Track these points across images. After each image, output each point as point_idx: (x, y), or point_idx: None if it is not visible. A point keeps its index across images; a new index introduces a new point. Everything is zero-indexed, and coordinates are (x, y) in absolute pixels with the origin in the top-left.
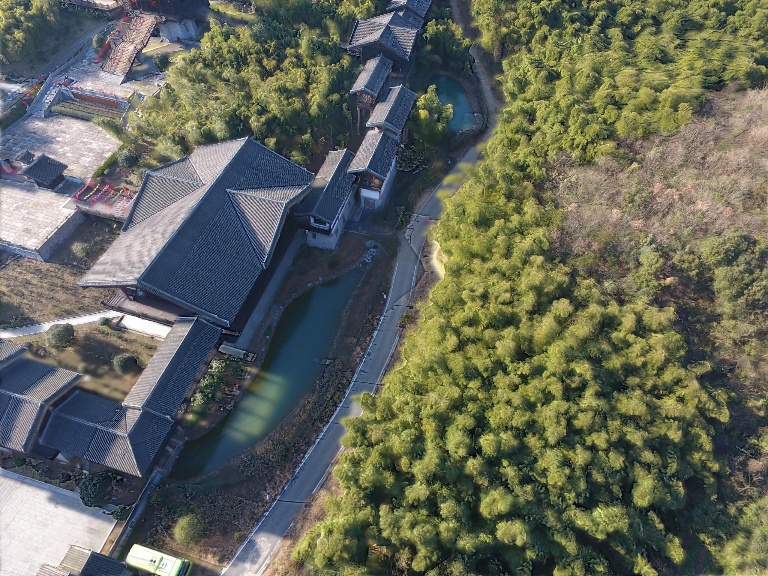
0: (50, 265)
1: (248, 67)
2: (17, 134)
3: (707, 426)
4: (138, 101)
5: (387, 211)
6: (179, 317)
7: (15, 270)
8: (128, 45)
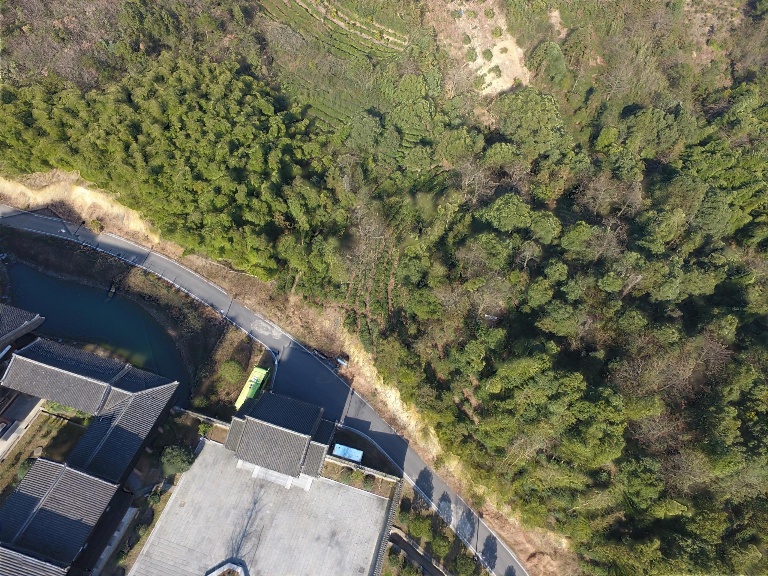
0: None
1: None
2: None
3: (240, 75)
4: None
5: None
6: (2, 380)
7: None
8: None
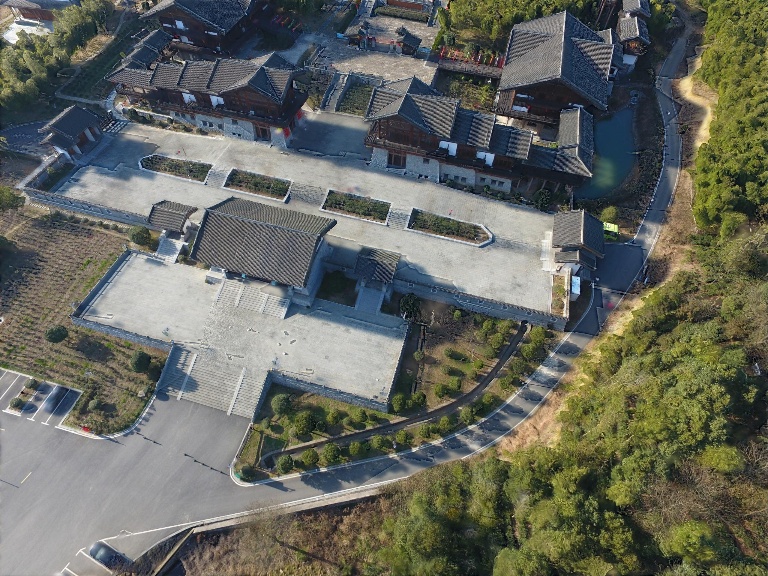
0: None
1: None
2: None
3: None
4: (437, 5)
5: None
6: (564, 110)
7: None
8: None
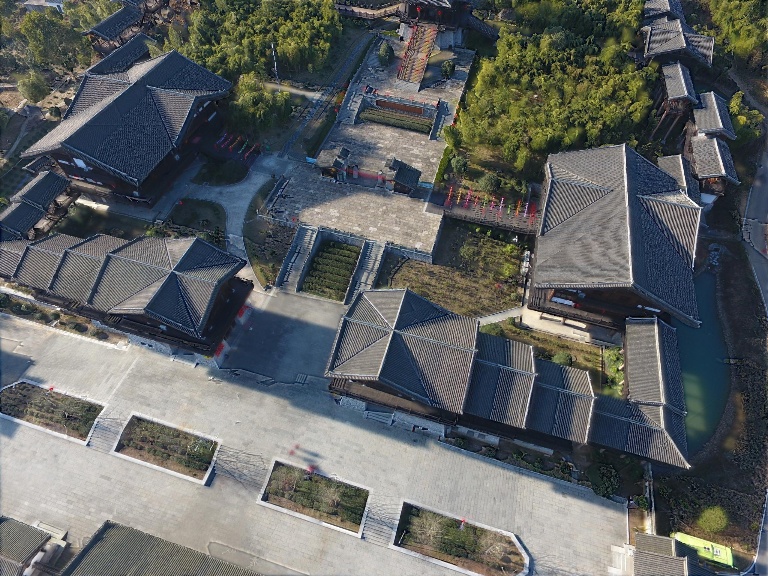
0: (439, 267)
1: (553, 75)
2: (339, 141)
3: None
4: (442, 108)
5: (707, 215)
6: (631, 318)
7: (410, 272)
8: (416, 53)
